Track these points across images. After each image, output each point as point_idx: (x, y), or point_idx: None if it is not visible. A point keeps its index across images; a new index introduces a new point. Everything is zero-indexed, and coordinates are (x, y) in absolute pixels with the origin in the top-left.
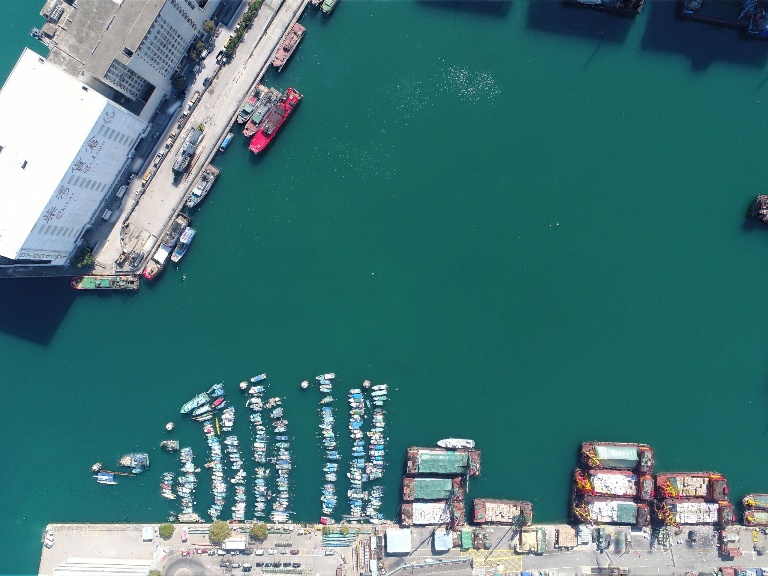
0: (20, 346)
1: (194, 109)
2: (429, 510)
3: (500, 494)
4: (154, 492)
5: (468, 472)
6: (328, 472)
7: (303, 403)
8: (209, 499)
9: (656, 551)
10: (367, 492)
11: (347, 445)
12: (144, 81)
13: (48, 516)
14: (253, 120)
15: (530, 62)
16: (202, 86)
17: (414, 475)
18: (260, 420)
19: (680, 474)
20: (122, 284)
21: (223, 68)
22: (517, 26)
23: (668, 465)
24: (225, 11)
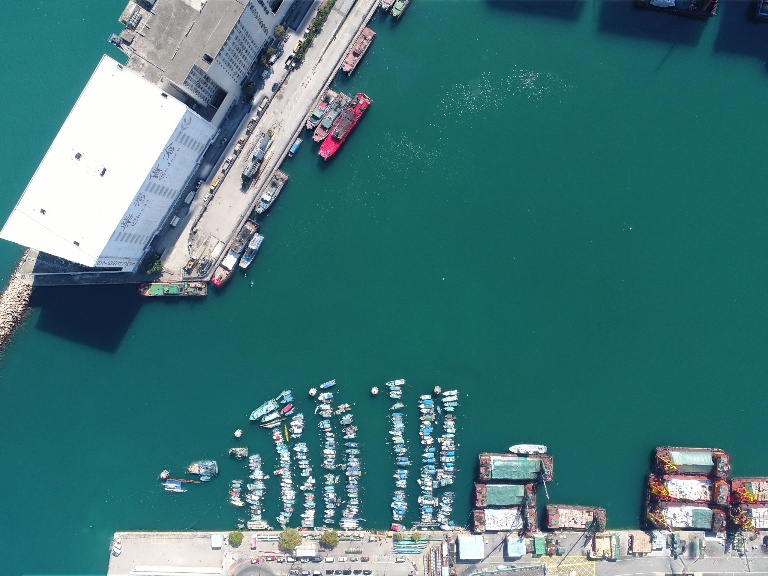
0: (87, 353)
1: (263, 114)
2: (501, 516)
3: (572, 500)
4: (222, 499)
5: (543, 478)
6: (398, 478)
7: (373, 409)
8: (278, 506)
9: (731, 556)
10: (438, 498)
11: (417, 451)
12: (216, 87)
13: (115, 524)
14: (323, 125)
15: (602, 65)
16: (270, 91)
17: (485, 481)
18: (329, 427)
19: (755, 479)
20: (190, 291)
21: (292, 73)
22: (588, 29)
23: (743, 470)
24: (294, 16)
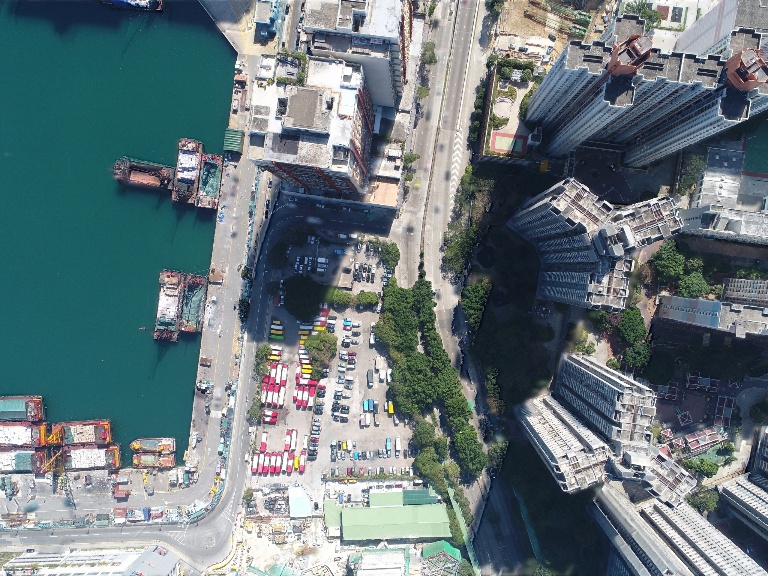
0: None
1: None
2: None
3: None
4: None
5: None
6: None
7: None
8: None
9: (59, 496)
10: None
11: None
12: None
13: None
14: None
15: None
16: None
17: None
18: None
19: (74, 423)
20: None
21: None
22: None
23: (65, 415)
24: None
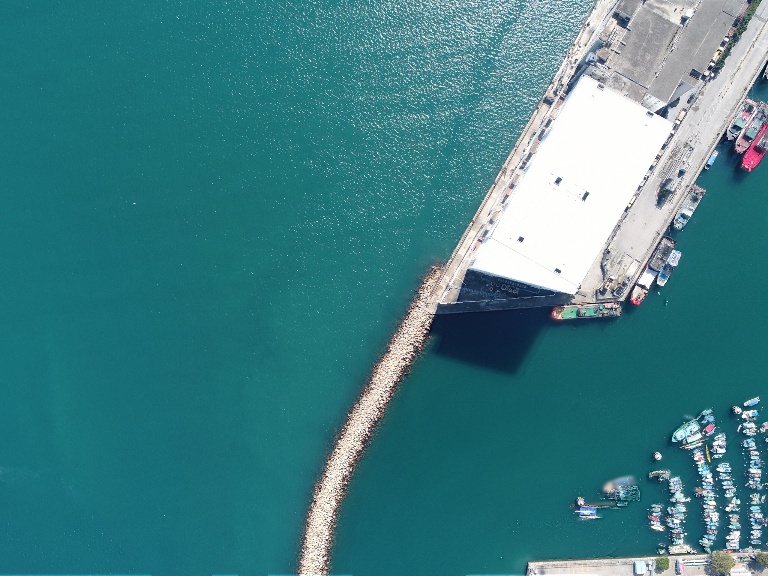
0: None
1: None
2: None
3: None
4: (641, 524)
5: None
6: None
7: None
8: (699, 529)
9: None
10: None
11: None
12: None
13: (525, 554)
14: (748, 136)
15: None
16: (686, 103)
17: None
18: (754, 445)
19: None
20: (606, 312)
21: (708, 83)
22: None
23: None
24: None
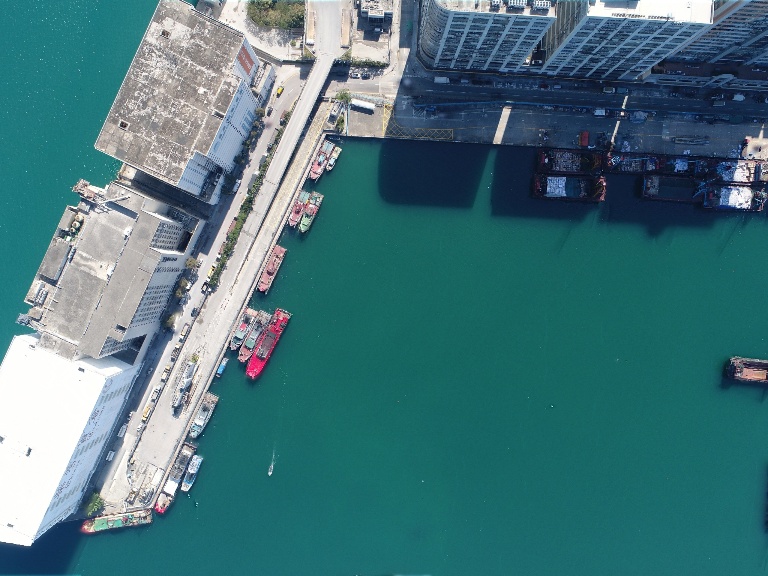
0: None
1: (185, 340)
2: None
3: None
4: None
5: None
6: None
7: None
8: None
9: None
10: None
11: None
12: None
13: None
14: (247, 346)
15: (506, 256)
16: (190, 317)
17: None
18: None
19: None
20: (135, 521)
21: (209, 297)
22: (490, 222)
23: None
24: (204, 241)
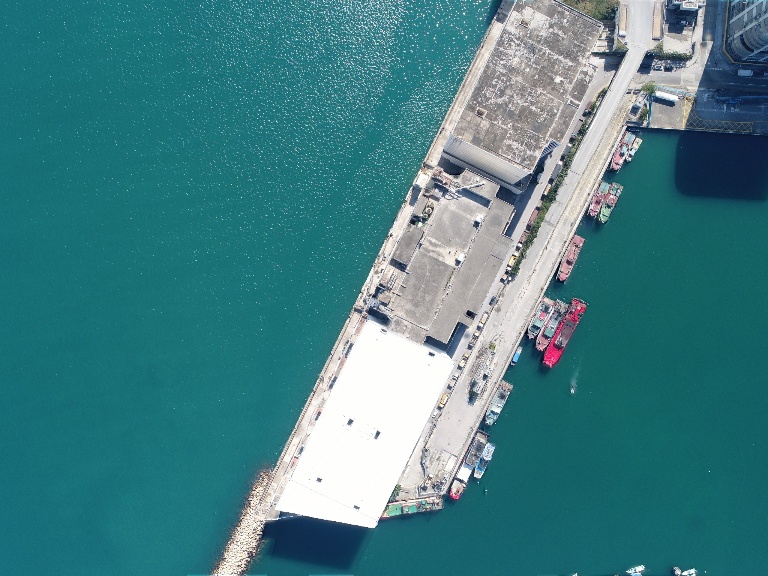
0: None
1: (483, 328)
2: None
3: None
4: None
5: None
6: None
7: None
8: None
9: None
10: None
11: None
12: None
13: None
14: (546, 335)
15: None
16: (488, 305)
17: None
18: None
19: None
20: (428, 507)
21: (507, 286)
22: None
23: None
24: None
